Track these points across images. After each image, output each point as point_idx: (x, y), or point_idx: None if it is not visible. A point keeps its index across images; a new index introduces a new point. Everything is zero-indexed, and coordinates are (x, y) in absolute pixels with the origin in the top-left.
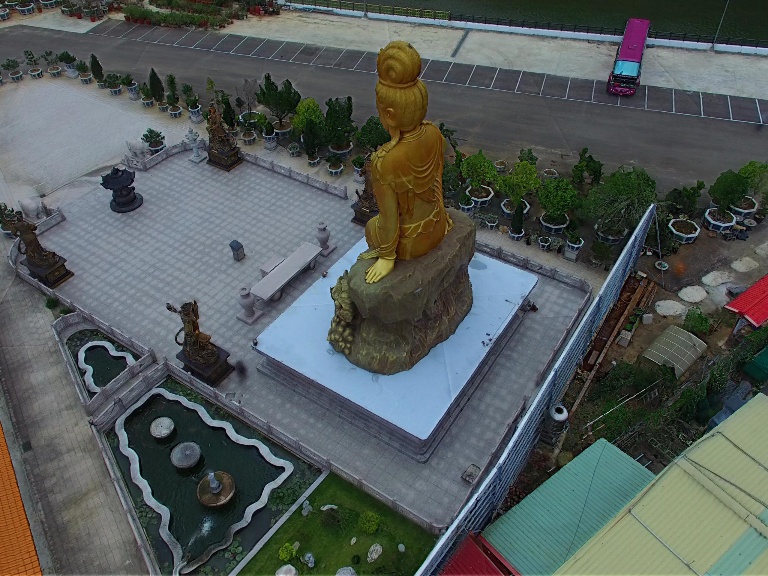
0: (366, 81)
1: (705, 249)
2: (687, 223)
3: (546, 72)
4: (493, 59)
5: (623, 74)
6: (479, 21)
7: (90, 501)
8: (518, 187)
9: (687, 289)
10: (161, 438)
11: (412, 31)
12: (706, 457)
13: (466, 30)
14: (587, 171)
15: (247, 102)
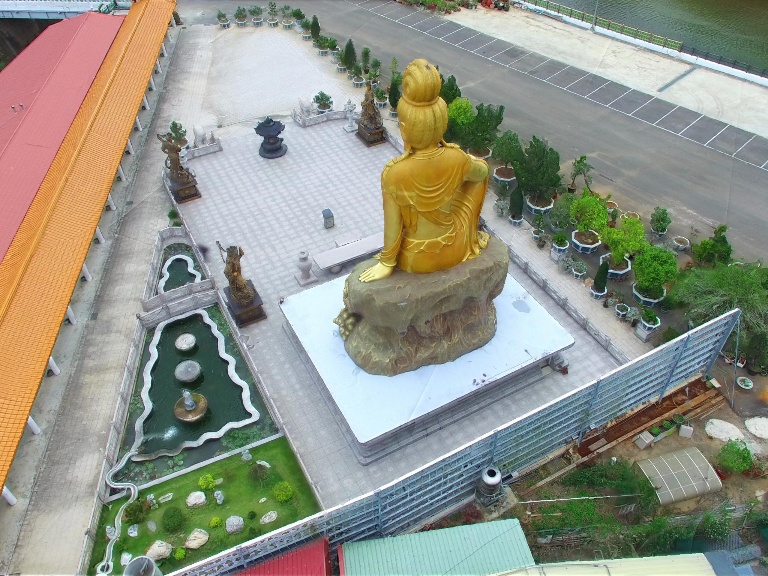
0: (550, 95)
1: None
2: None
3: (757, 132)
4: (703, 104)
5: None
6: (712, 59)
7: (108, 375)
8: None
9: (761, 419)
10: (180, 350)
11: (632, 55)
12: None
13: (694, 66)
14: None
15: None
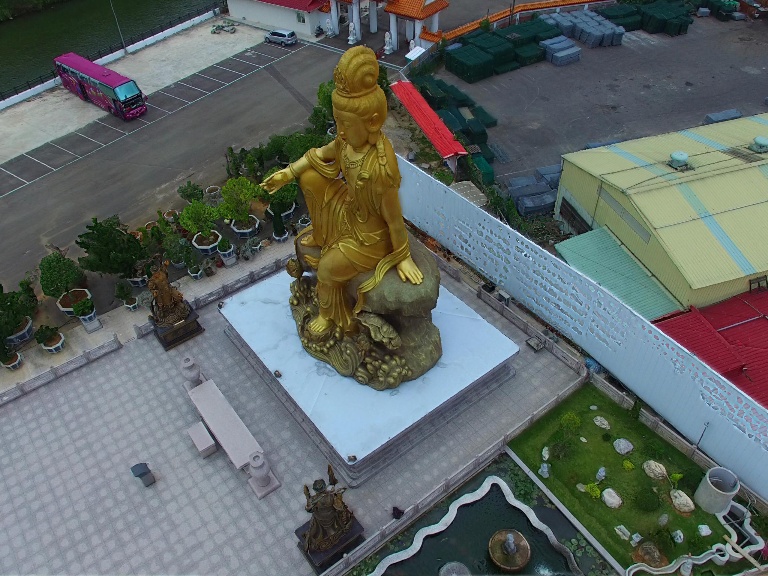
0: None
1: None
2: None
3: (46, 141)
4: None
5: (128, 97)
6: None
7: None
8: (240, 205)
9: None
10: None
11: None
12: (623, 184)
13: None
14: None
15: None
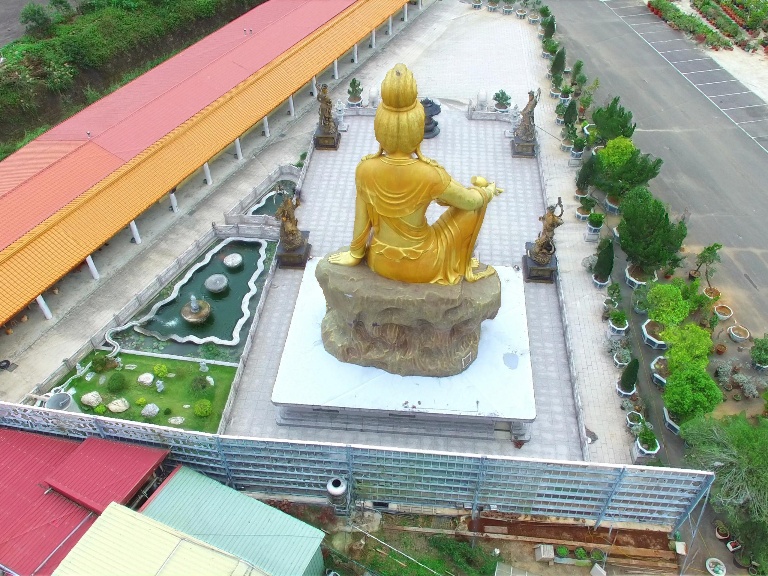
0: (761, 170)
1: None
2: None
3: None
4: None
5: None
6: None
7: (167, 260)
8: None
9: None
10: (226, 264)
11: None
12: None
13: None
14: None
15: None
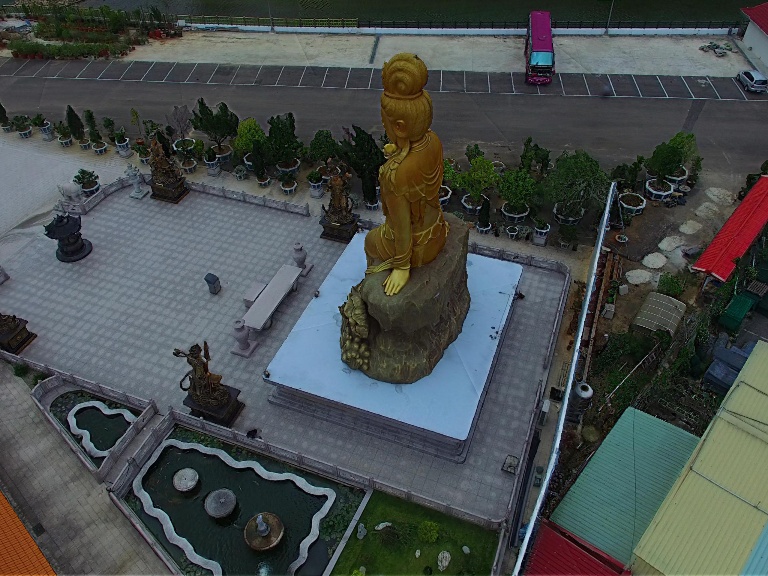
0: (292, 95)
1: (653, 218)
2: (633, 196)
3: (464, 69)
4: None
5: (539, 64)
6: (388, 26)
7: (129, 573)
8: (477, 182)
9: (649, 257)
10: (188, 491)
11: (324, 41)
12: (741, 406)
13: (376, 36)
14: (534, 159)
15: (179, 130)
